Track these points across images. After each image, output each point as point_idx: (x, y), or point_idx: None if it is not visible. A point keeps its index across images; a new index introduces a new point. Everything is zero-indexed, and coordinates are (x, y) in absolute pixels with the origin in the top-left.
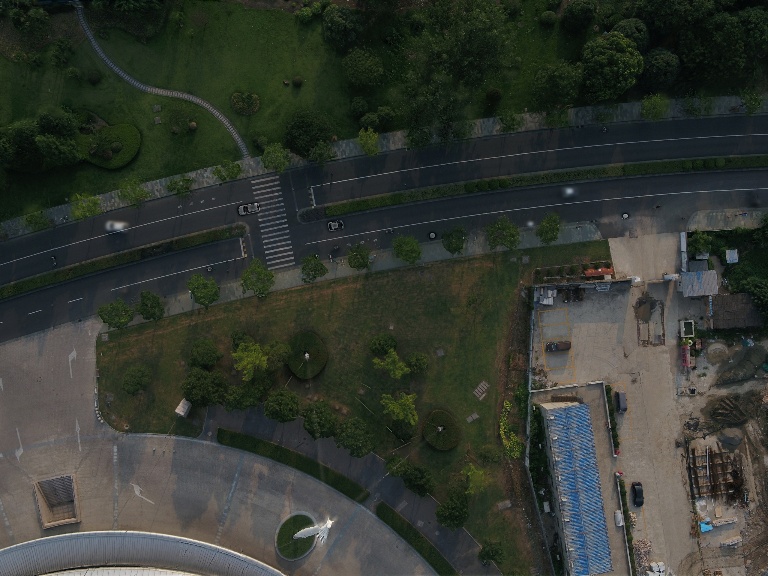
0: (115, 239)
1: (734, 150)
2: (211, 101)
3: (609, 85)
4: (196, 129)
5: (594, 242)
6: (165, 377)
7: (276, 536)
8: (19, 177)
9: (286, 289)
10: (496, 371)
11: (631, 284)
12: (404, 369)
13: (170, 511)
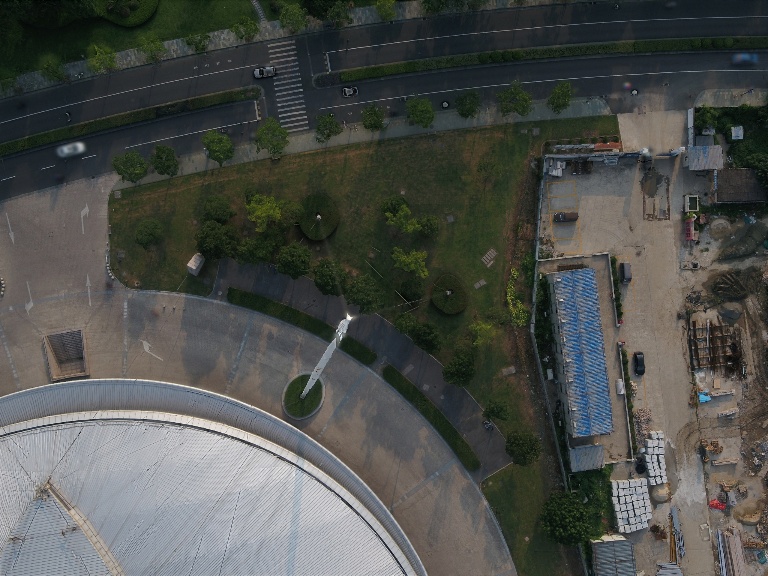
0: (130, 97)
1: (742, 31)
2: None
3: None
4: None
5: (603, 117)
6: (177, 235)
7: (283, 395)
8: (36, 32)
9: (299, 153)
10: (504, 239)
11: (638, 159)
12: (416, 225)
13: (179, 368)
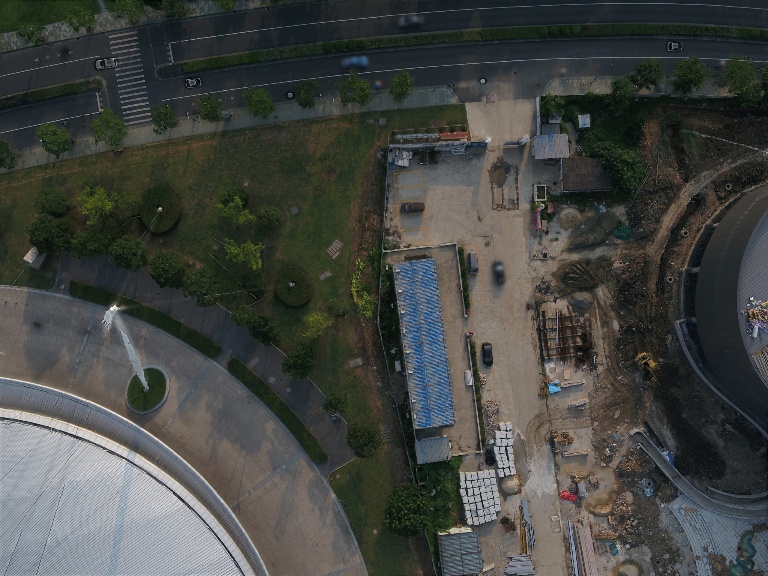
0: None
1: (591, 18)
2: None
3: None
4: None
5: (451, 106)
6: (18, 229)
7: (126, 389)
8: None
9: (142, 145)
10: (350, 230)
11: (487, 148)
12: (248, 216)
13: (21, 363)
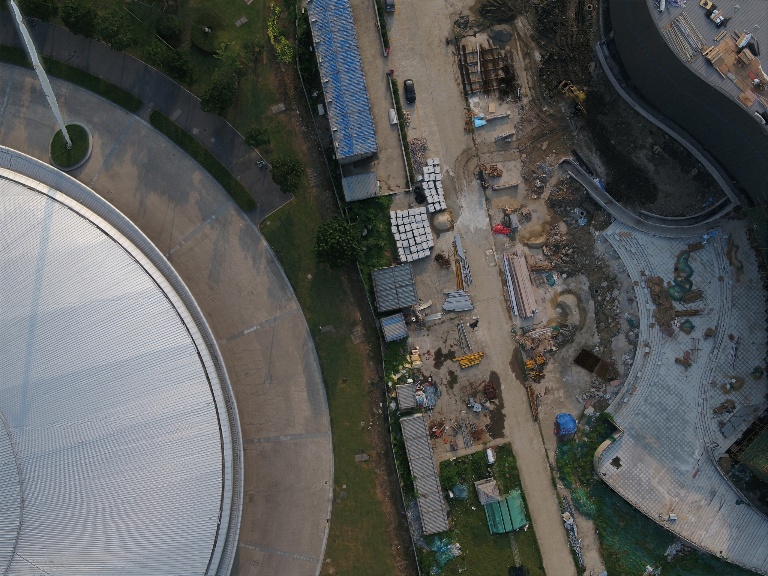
0: None
1: None
2: None
3: None
4: None
5: None
6: None
7: (50, 147)
8: None
9: None
10: None
11: None
12: None
13: None
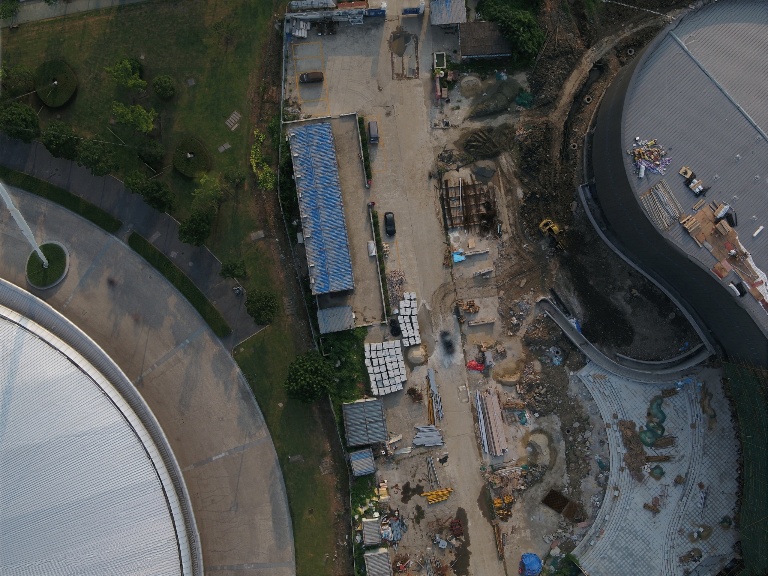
0: None
1: None
2: None
3: None
4: None
5: None
6: None
7: (26, 265)
8: None
9: (38, 21)
10: (248, 102)
11: (385, 18)
12: (138, 80)
13: None
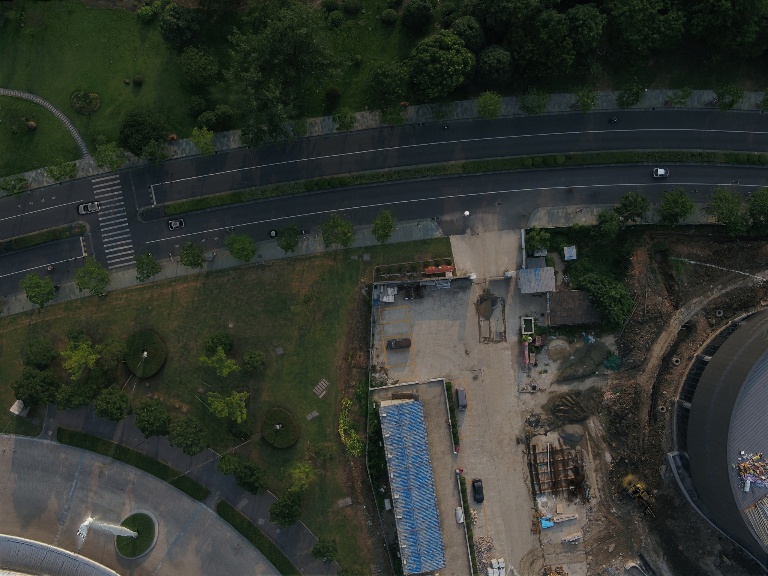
0: None
1: (575, 147)
2: (51, 100)
3: (435, 82)
4: (36, 128)
5: (435, 239)
6: (5, 376)
7: (116, 535)
8: None
9: (127, 288)
10: (336, 369)
11: (472, 281)
12: (232, 367)
13: (10, 510)
